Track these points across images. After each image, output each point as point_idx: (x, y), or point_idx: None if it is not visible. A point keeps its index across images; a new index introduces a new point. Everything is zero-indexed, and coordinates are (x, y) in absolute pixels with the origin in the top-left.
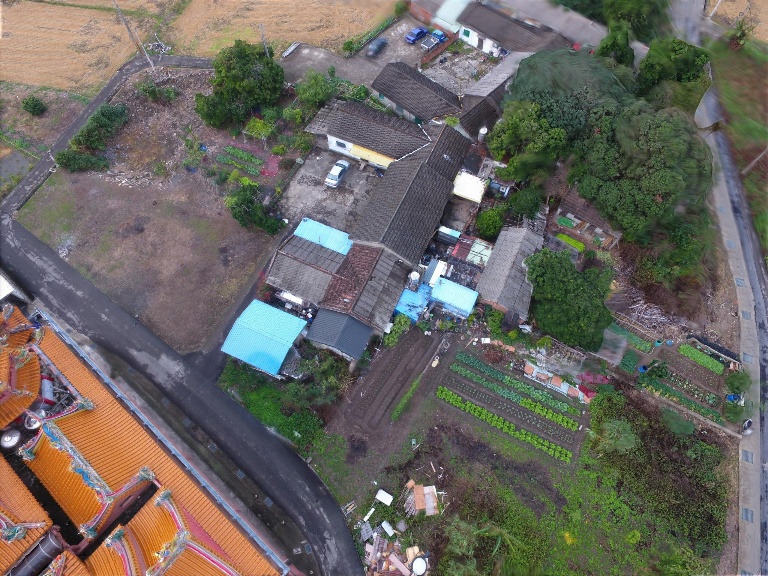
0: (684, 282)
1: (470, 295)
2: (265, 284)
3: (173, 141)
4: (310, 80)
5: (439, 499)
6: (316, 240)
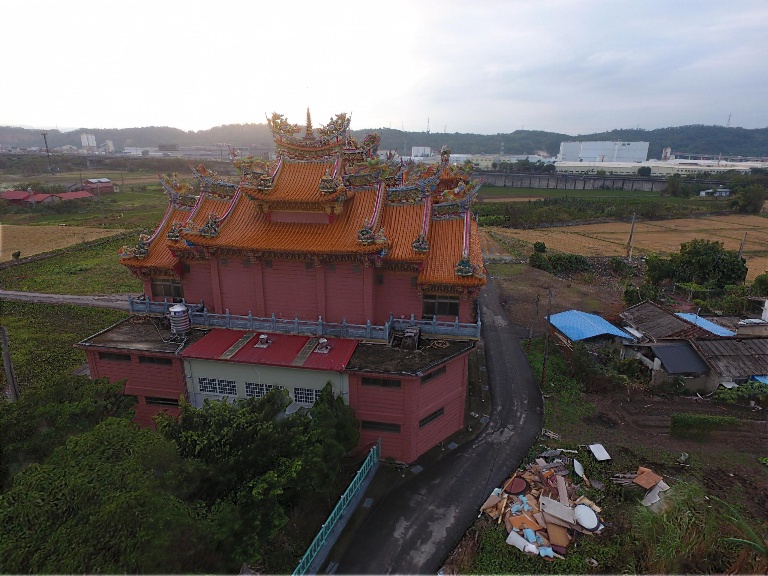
0: None
1: None
2: None
3: None
4: None
5: None
6: (693, 322)
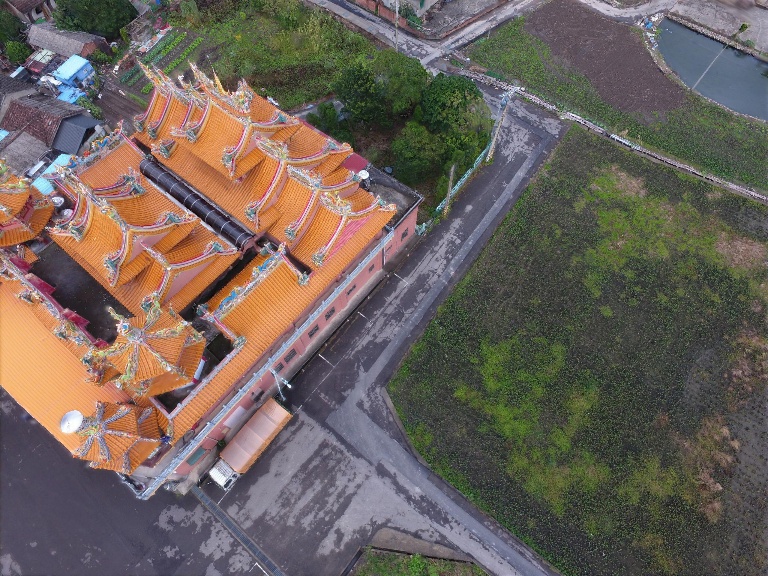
0: None
1: (74, 59)
2: None
3: None
4: None
5: None
6: None
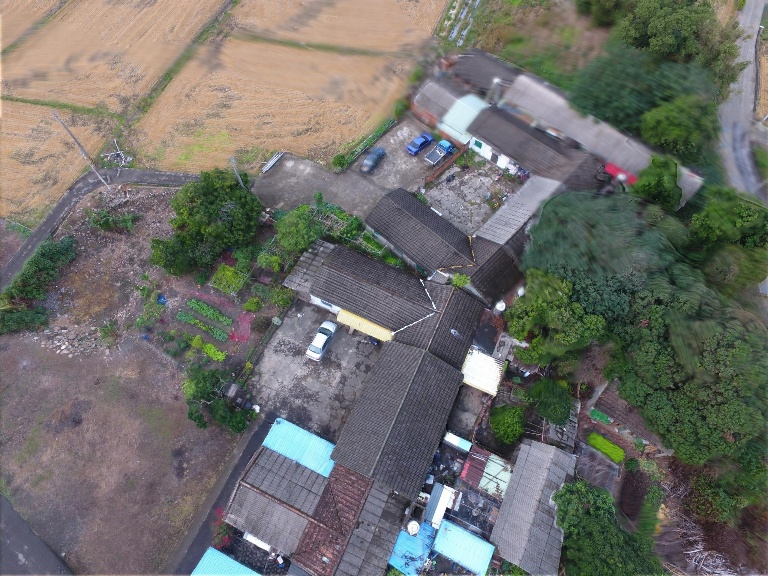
0: (752, 514)
1: (484, 550)
2: (223, 525)
3: (129, 282)
4: (290, 225)
5: None
6: (291, 454)
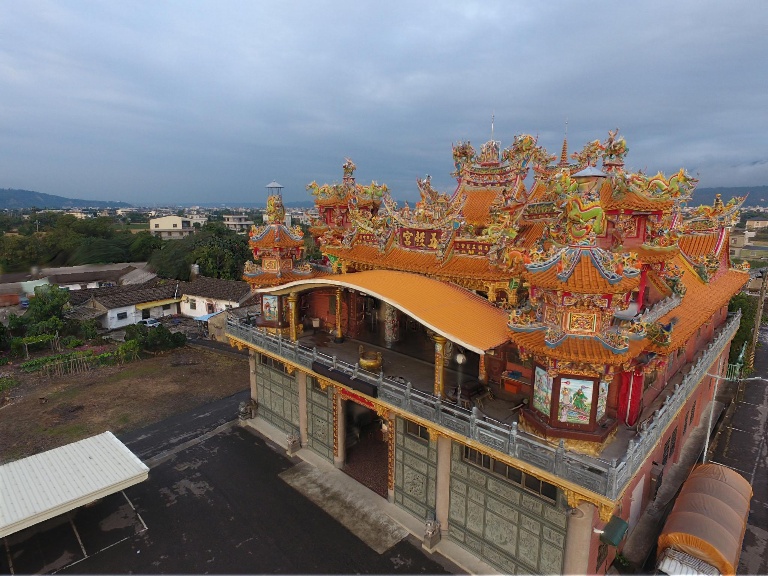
0: None
1: None
2: None
3: None
4: (43, 294)
5: None
6: None
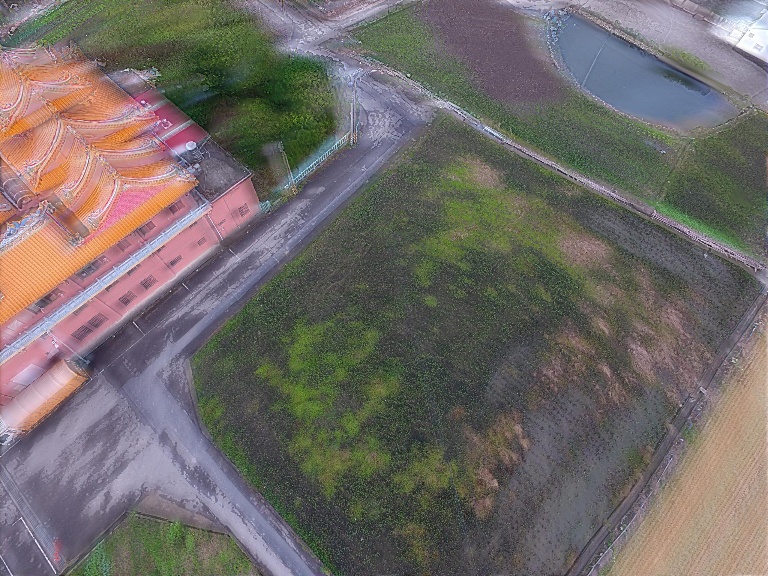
0: None
1: None
2: None
3: None
4: None
5: (98, 61)
6: None
